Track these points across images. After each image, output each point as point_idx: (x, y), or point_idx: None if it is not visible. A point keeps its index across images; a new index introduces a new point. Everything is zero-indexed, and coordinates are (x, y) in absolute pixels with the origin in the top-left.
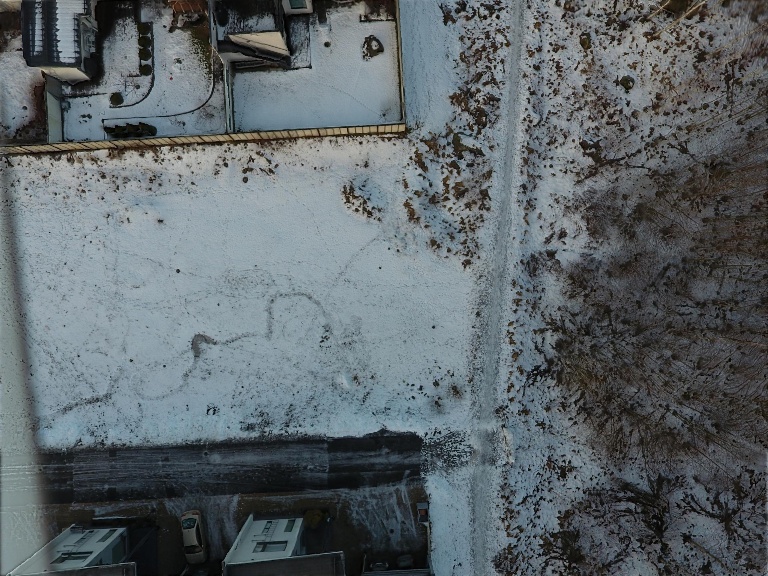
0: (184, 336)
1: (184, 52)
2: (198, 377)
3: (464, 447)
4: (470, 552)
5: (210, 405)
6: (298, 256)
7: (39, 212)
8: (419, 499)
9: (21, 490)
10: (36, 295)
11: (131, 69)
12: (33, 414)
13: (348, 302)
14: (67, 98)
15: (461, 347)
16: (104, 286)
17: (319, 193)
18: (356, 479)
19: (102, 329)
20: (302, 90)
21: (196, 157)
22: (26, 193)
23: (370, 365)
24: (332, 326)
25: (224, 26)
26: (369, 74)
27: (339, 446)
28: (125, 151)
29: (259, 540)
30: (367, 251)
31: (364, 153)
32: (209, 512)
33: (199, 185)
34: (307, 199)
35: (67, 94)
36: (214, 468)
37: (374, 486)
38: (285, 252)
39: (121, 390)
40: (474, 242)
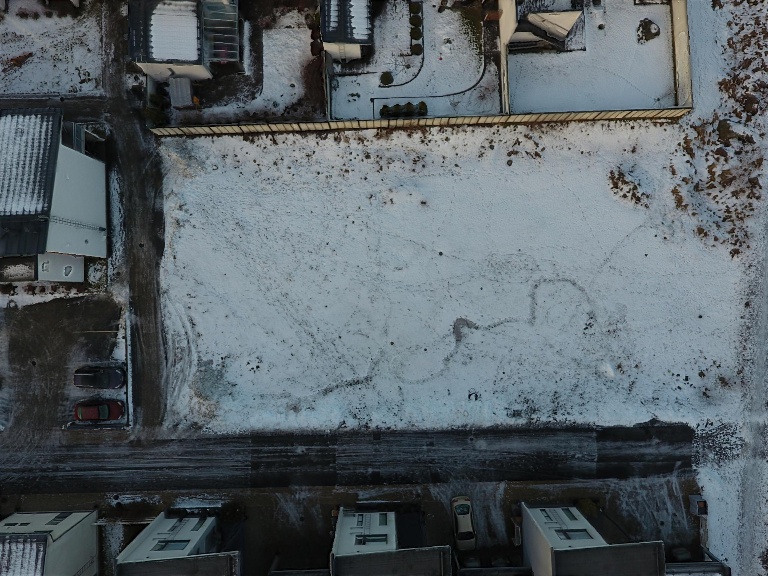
0: (446, 320)
1: (454, 32)
2: (459, 361)
3: (735, 439)
4: (737, 547)
5: (471, 390)
6: (563, 241)
7: (301, 191)
8: (691, 491)
9: (283, 471)
10: (298, 275)
11: (402, 48)
12: (293, 395)
13: (613, 289)
14: (336, 76)
15: (729, 338)
16: (366, 267)
17: (585, 178)
18: (625, 469)
19: (364, 310)
20: (575, 73)
21: (464, 139)
22: (289, 171)
23: (635, 354)
24: (596, 313)
25: (520, 5)
26: (644, 58)
27: (608, 435)
28: (394, 131)
29: (556, 527)
30: (633, 238)
31: (633, 138)
32: (475, 499)
33: (463, 167)
34: (573, 184)
35: (337, 72)
36: (480, 454)
37: (644, 477)
38: (550, 237)
39: (381, 373)
40: (743, 231)
